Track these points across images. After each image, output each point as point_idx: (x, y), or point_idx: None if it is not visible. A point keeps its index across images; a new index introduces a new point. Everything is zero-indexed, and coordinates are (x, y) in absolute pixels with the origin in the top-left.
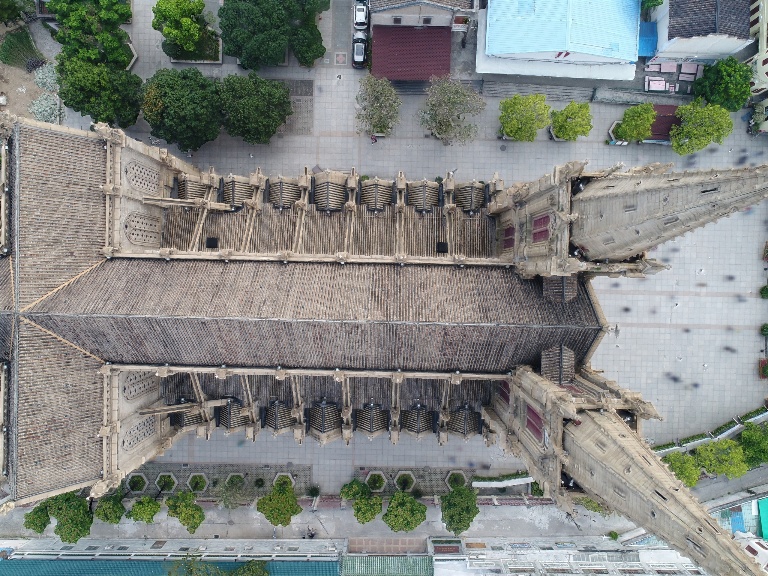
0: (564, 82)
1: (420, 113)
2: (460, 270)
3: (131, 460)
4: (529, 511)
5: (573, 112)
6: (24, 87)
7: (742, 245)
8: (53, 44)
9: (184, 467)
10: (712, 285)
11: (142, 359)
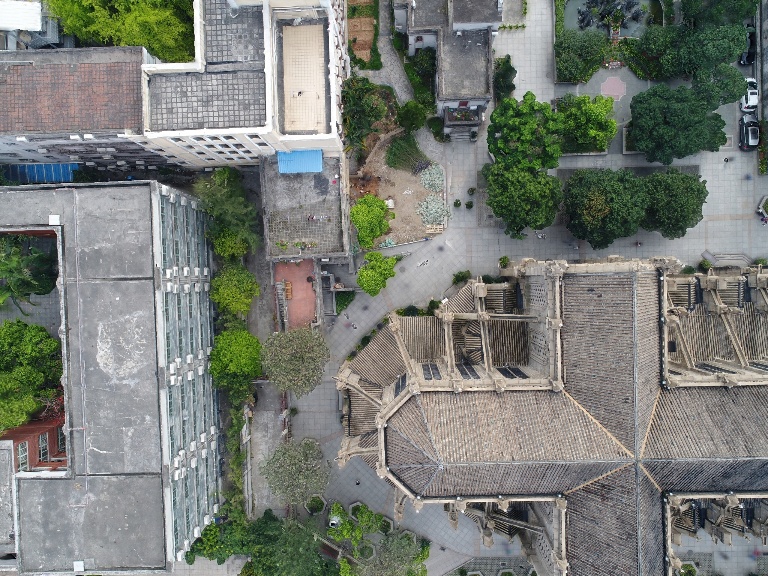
0: None
1: None
2: None
3: None
4: None
5: None
6: (411, 189)
7: None
8: (436, 145)
9: None
10: None
11: (705, 488)
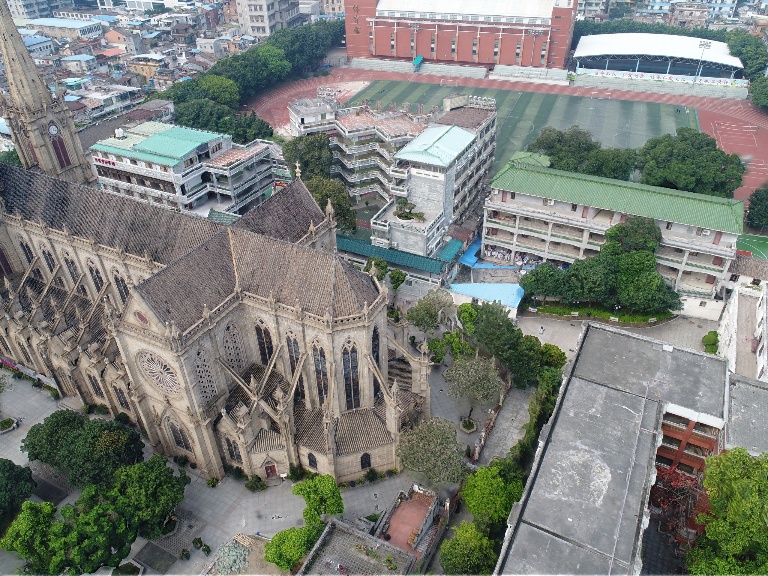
0: None
1: None
2: (27, 219)
3: None
4: None
5: None
6: None
7: None
8: None
9: None
10: None
11: None
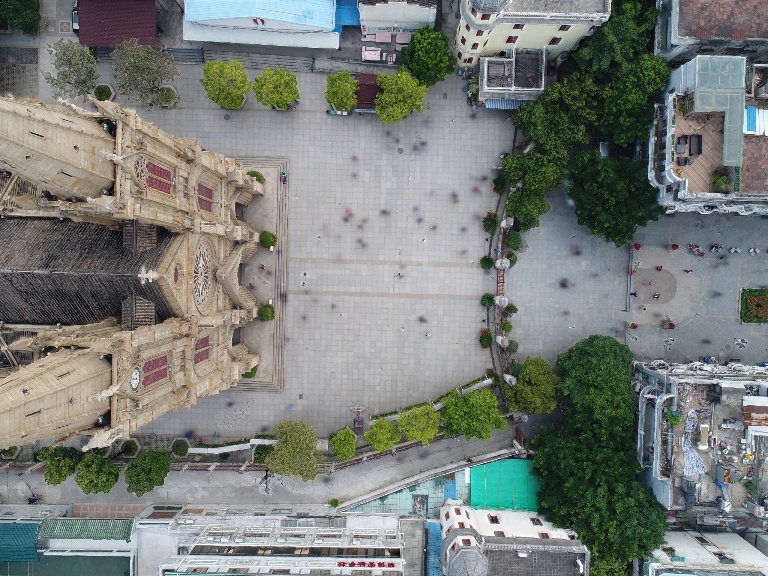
0: (283, 52)
1: (118, 79)
2: (61, 223)
3: None
4: (253, 478)
5: (265, 78)
6: None
7: (464, 215)
8: None
9: None
10: (434, 255)
11: None
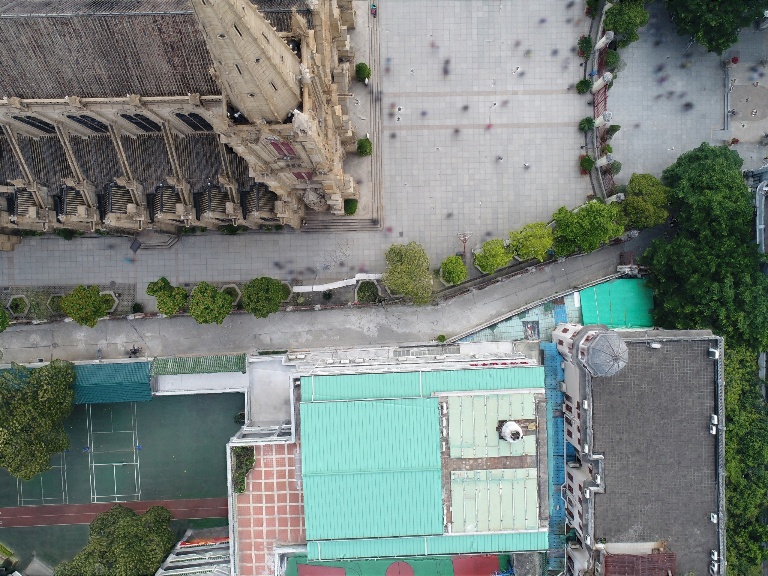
0: None
1: None
2: None
3: None
4: (357, 319)
5: None
6: None
7: (557, 41)
8: None
9: (5, 291)
10: (529, 83)
11: None
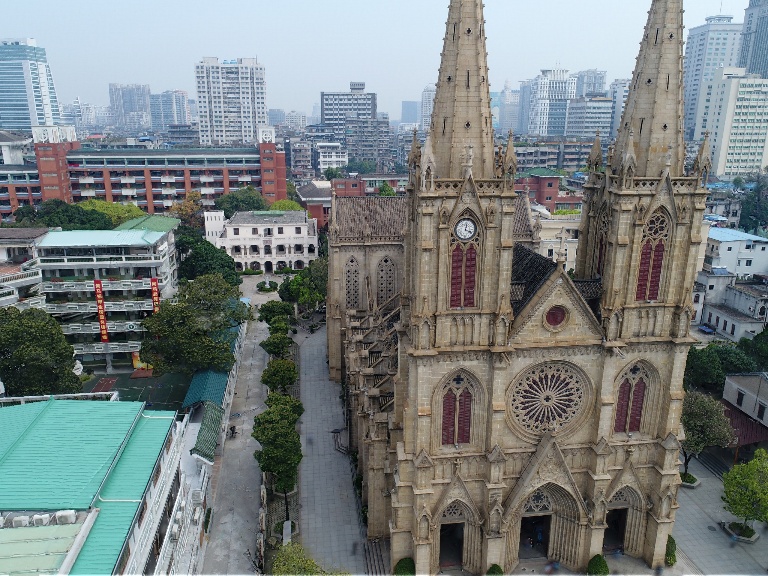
0: None
1: None
2: None
3: (339, 268)
4: None
5: None
6: None
7: None
8: None
9: None
10: None
11: None
